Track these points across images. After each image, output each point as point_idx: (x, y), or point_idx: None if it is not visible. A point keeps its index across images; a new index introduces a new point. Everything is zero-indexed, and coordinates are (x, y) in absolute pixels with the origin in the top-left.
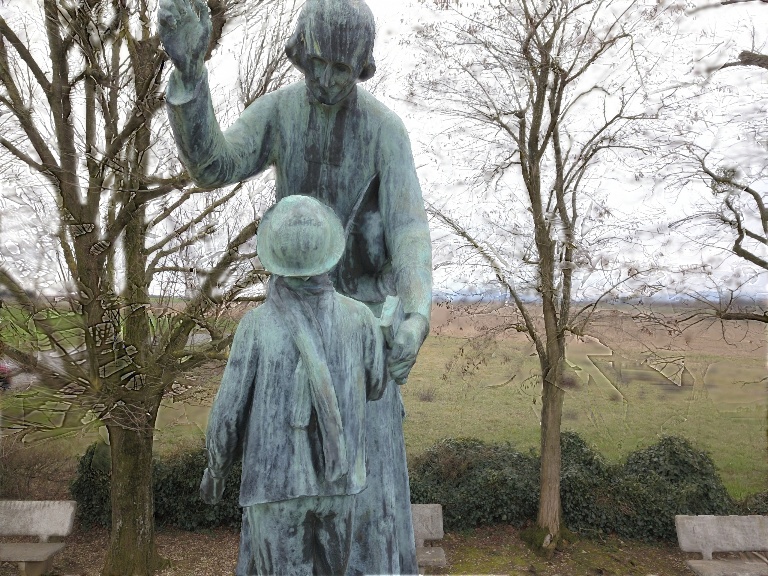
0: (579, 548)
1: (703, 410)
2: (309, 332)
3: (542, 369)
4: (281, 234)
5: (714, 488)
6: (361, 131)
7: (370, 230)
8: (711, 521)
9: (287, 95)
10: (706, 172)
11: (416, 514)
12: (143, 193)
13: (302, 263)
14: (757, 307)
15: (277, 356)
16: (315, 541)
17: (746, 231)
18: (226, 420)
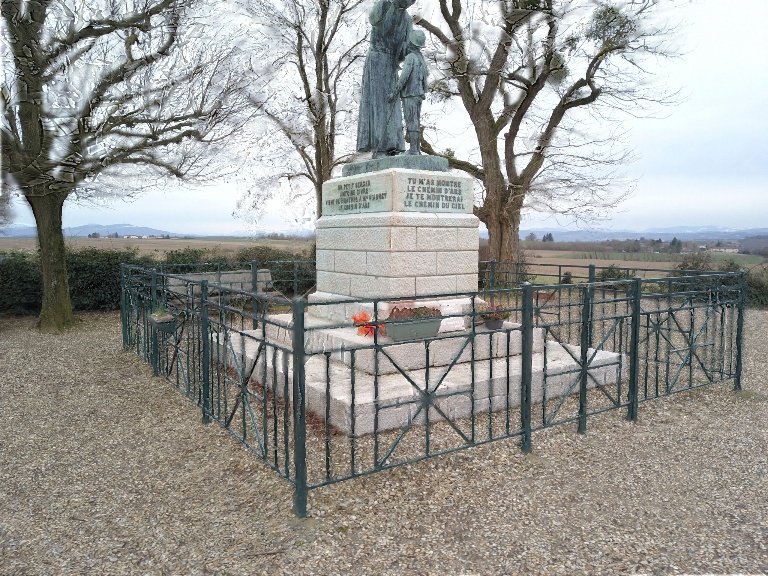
0: None
1: None
2: None
3: (317, 194)
4: (420, 37)
5: None
6: (405, 18)
7: (404, 46)
8: None
9: None
10: None
11: None
12: (90, 30)
13: (422, 44)
14: None
15: (417, 64)
16: None
17: None
18: (407, 77)
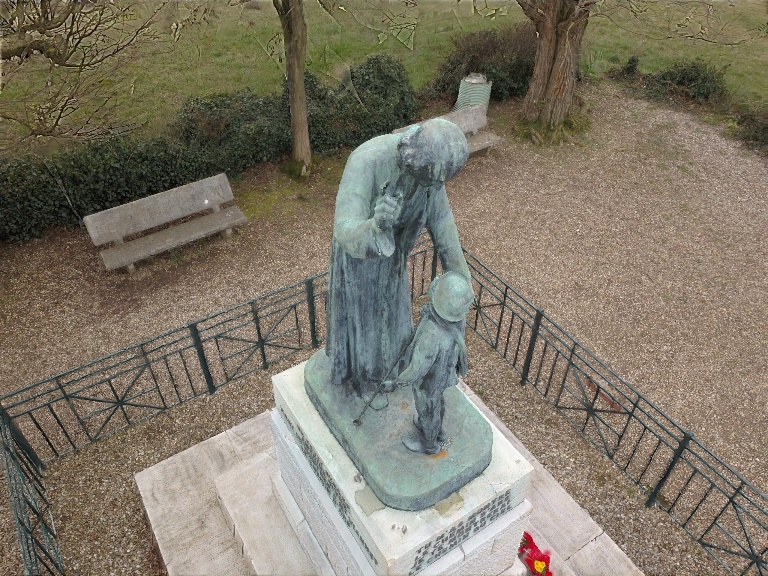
0: (325, 167)
1: None
2: (460, 334)
3: (283, 26)
4: None
5: (407, 91)
6: None
7: None
8: None
9: (381, 165)
10: None
11: (207, 187)
12: None
13: None
14: None
15: (448, 348)
16: None
17: None
18: None
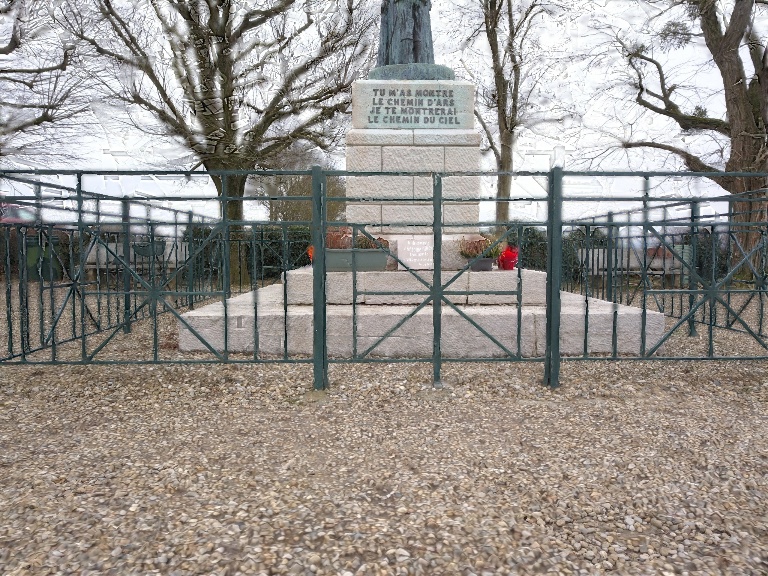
0: None
1: (608, 208)
2: None
3: (497, 165)
4: None
5: None
6: None
7: None
8: (600, 251)
9: None
10: (618, 42)
11: None
12: (246, 23)
13: None
14: (648, 136)
15: None
16: (414, 15)
17: (650, 92)
18: None
